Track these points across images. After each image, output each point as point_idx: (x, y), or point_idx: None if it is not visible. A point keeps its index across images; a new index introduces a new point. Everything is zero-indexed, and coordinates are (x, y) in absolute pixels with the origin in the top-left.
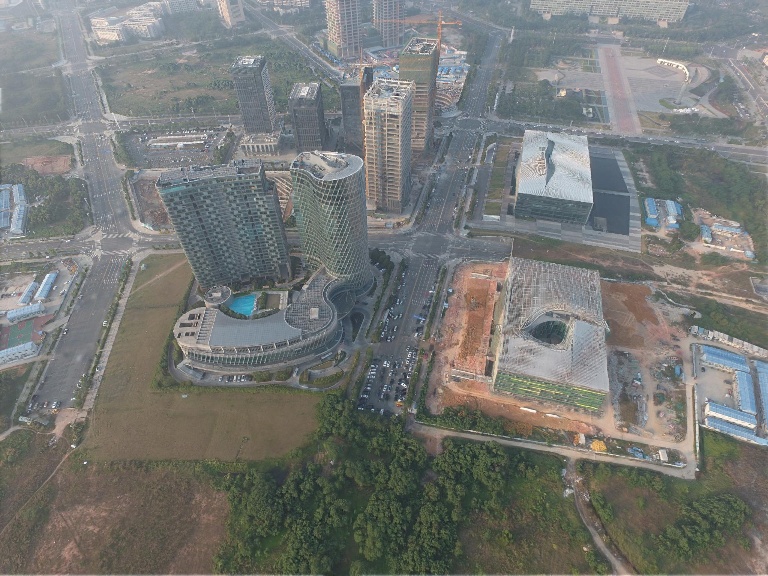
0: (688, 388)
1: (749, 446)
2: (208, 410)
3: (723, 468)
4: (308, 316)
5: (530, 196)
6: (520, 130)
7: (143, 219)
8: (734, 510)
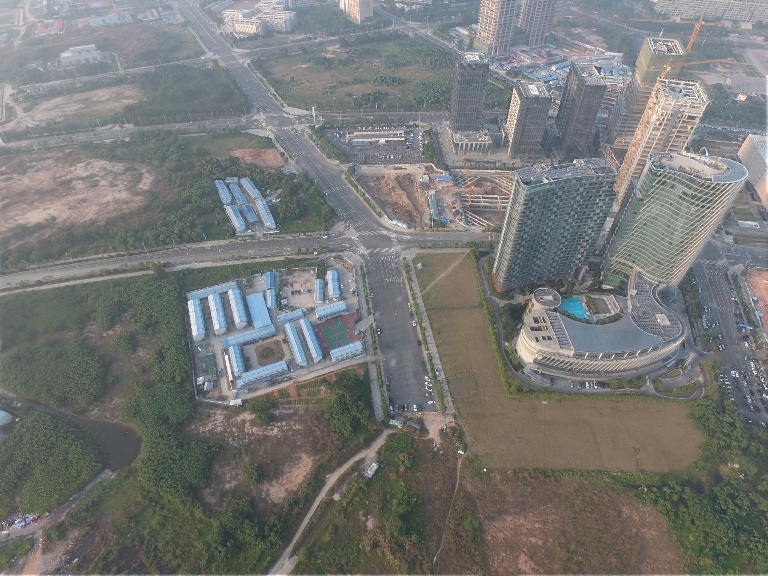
0: None
1: None
2: (578, 418)
3: None
4: (656, 322)
5: None
6: (725, 134)
7: (389, 216)
8: None
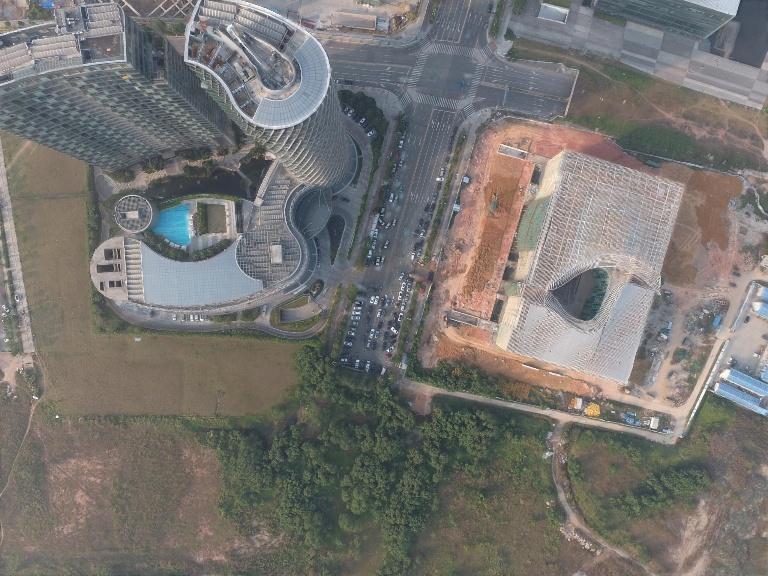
0: (717, 343)
1: (746, 415)
2: (170, 358)
3: (707, 440)
4: (268, 257)
5: None
6: None
7: None
8: (696, 484)
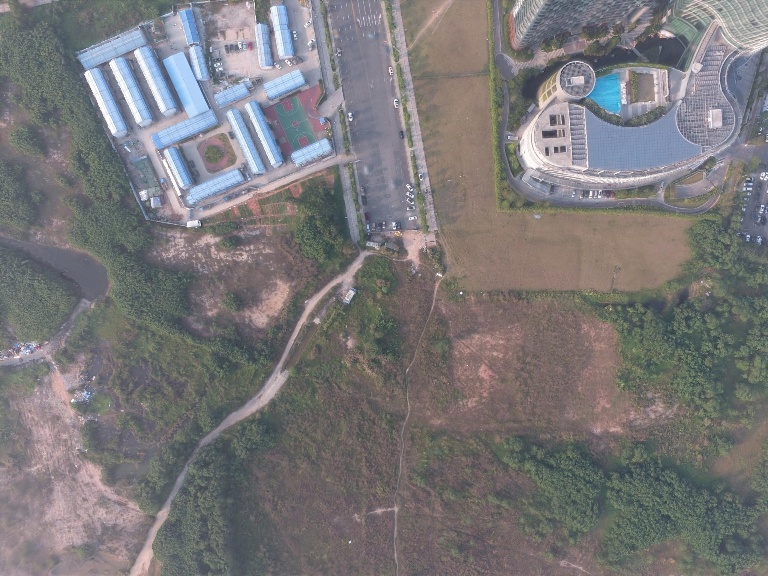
0: None
1: None
2: (569, 234)
3: None
4: (706, 122)
5: None
6: None
7: None
8: None
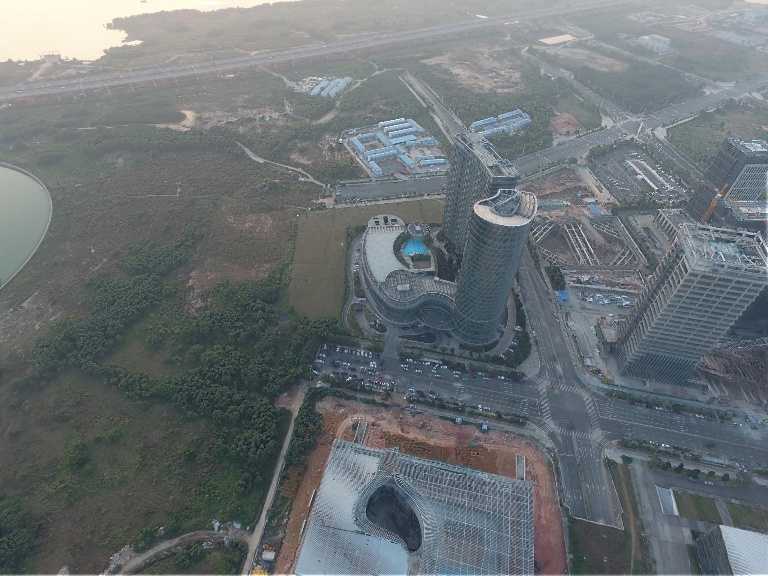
0: None
1: None
2: (330, 258)
3: None
4: None
5: (725, 551)
6: None
7: (520, 183)
8: None
